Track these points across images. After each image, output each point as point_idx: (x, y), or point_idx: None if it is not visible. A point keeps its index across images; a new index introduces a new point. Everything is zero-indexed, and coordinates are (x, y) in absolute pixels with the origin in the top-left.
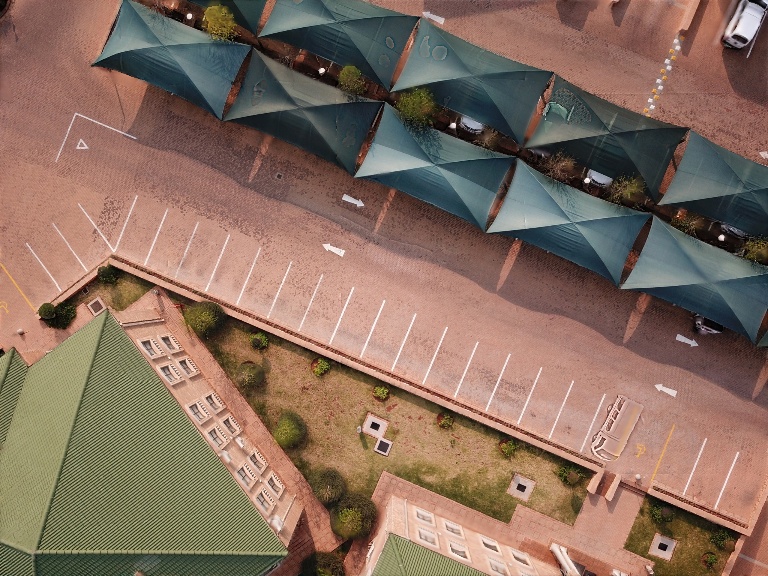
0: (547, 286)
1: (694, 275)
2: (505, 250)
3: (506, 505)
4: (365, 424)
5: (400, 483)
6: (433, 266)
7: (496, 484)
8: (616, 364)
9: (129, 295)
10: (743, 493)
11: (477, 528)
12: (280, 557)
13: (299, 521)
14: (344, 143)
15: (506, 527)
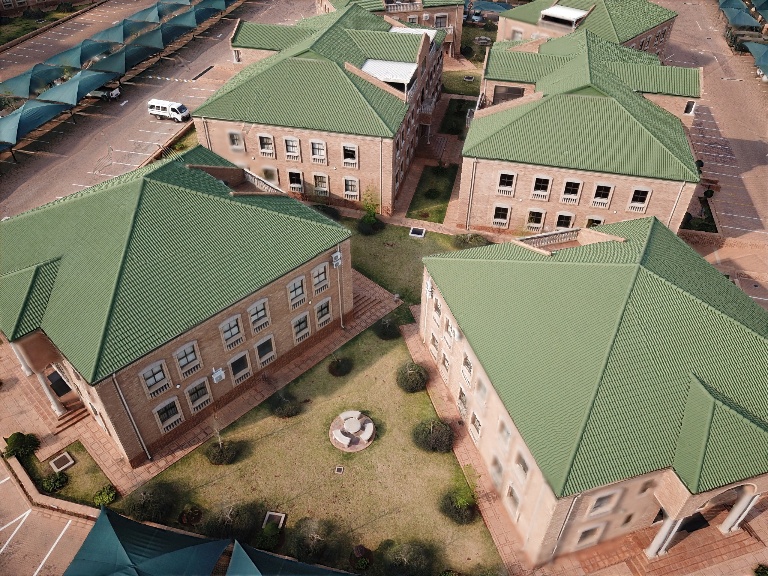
0: (72, 141)
1: None
2: (40, 156)
3: None
4: None
5: None
6: (38, 180)
7: None
8: None
9: None
10: (216, 86)
11: None
12: (202, 146)
13: None
14: None
15: None
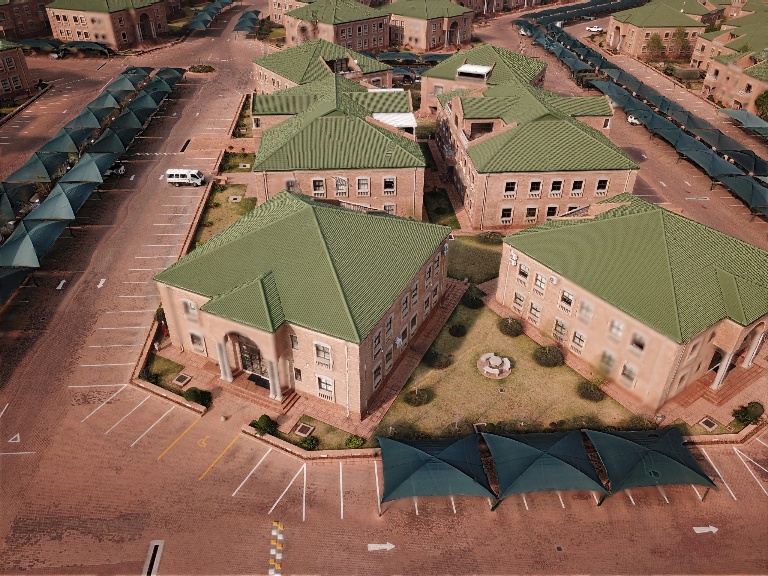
0: None
1: None
2: (90, 229)
3: (247, 200)
4: None
5: None
6: (106, 248)
7: None
8: None
9: (165, 365)
10: None
11: None
12: None
13: None
14: (13, 298)
15: None
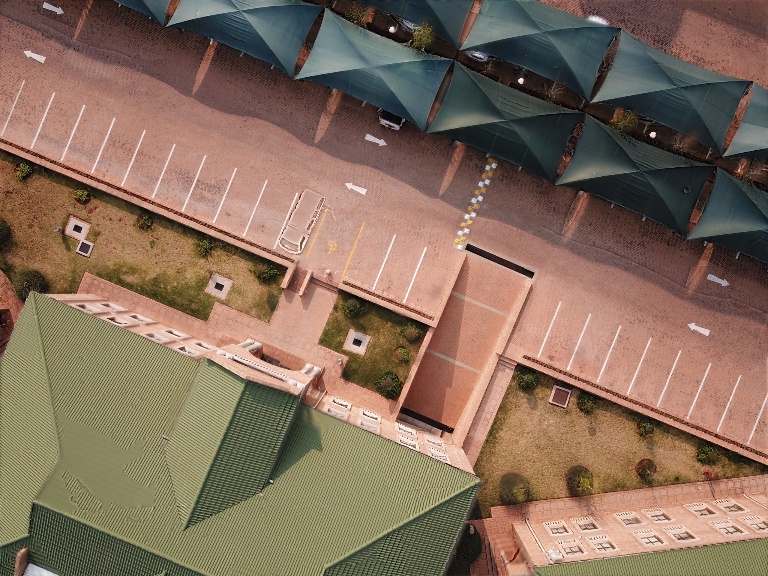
0: (241, 89)
1: (358, 61)
2: (200, 55)
3: (204, 303)
4: (68, 227)
5: (101, 283)
6: (131, 71)
7: (194, 283)
8: (308, 164)
9: None
10: (431, 287)
11: (176, 326)
12: None
13: (4, 323)
14: None
15: (204, 325)
